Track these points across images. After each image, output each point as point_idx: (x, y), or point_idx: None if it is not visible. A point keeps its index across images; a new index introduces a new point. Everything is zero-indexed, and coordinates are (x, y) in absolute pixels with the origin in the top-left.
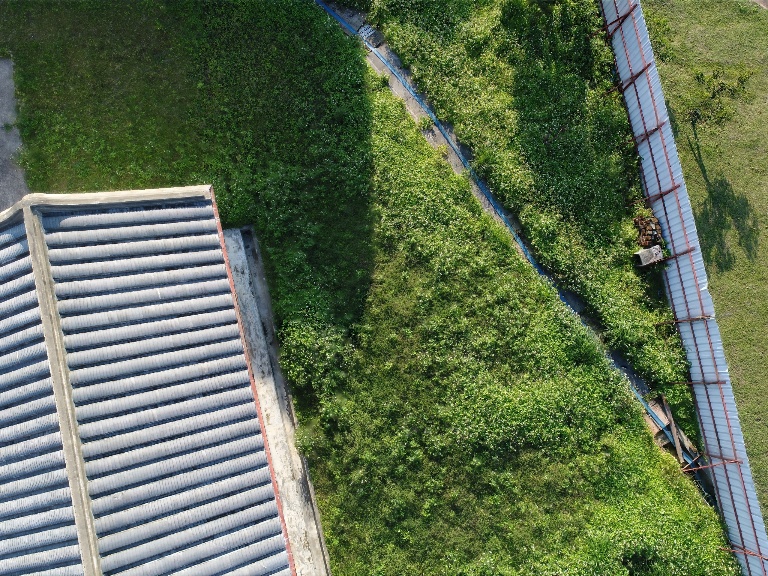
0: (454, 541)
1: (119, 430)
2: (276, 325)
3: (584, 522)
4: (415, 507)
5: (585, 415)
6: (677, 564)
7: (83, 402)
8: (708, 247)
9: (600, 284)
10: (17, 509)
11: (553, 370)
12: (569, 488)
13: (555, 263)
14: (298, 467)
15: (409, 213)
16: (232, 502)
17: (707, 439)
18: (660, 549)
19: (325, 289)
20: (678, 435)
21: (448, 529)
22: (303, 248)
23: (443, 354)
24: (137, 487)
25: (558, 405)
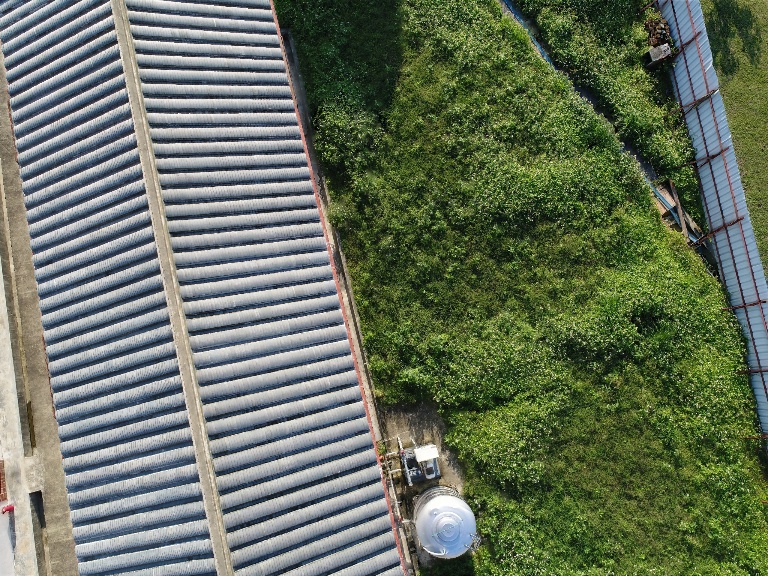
0: (475, 300)
1: (181, 124)
2: (311, 116)
3: (596, 286)
4: (439, 271)
5: (597, 192)
6: (682, 322)
7: (150, 96)
8: (714, 53)
9: (612, 79)
10: (91, 191)
11: (568, 152)
12: (582, 257)
13: (570, 60)
14: (330, 243)
15: (435, 13)
16: (280, 201)
17: (711, 218)
18: (666, 307)
19: (357, 81)
20: (684, 217)
21: (470, 290)
22: (336, 46)
23: (466, 136)
24: (198, 172)
25: (572, 181)
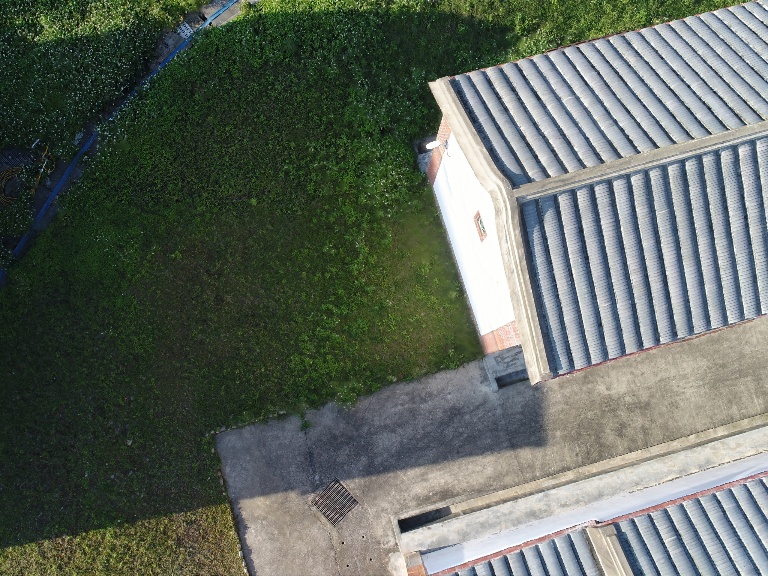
0: None
1: None
2: None
3: None
4: None
5: None
6: None
7: None
8: None
9: None
10: None
11: None
12: None
13: None
14: None
15: None
16: (759, 27)
17: None
18: None
19: None
20: None
21: None
22: None
23: None
24: None
25: None
